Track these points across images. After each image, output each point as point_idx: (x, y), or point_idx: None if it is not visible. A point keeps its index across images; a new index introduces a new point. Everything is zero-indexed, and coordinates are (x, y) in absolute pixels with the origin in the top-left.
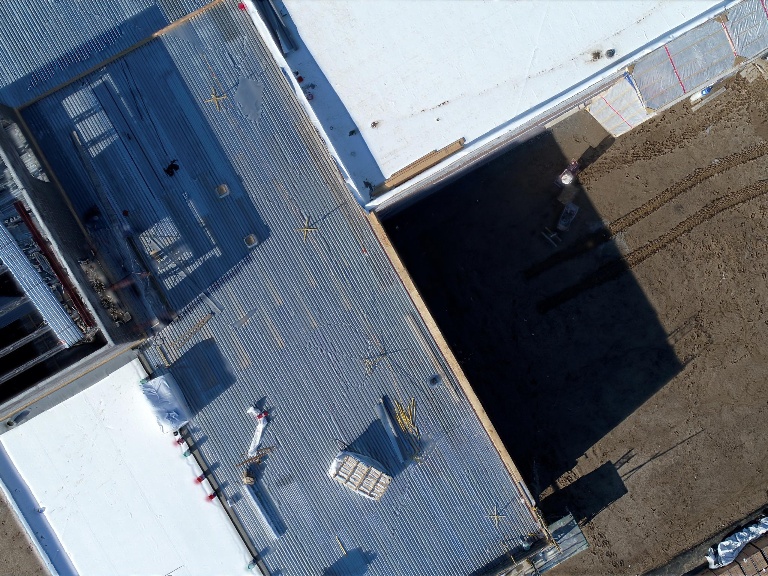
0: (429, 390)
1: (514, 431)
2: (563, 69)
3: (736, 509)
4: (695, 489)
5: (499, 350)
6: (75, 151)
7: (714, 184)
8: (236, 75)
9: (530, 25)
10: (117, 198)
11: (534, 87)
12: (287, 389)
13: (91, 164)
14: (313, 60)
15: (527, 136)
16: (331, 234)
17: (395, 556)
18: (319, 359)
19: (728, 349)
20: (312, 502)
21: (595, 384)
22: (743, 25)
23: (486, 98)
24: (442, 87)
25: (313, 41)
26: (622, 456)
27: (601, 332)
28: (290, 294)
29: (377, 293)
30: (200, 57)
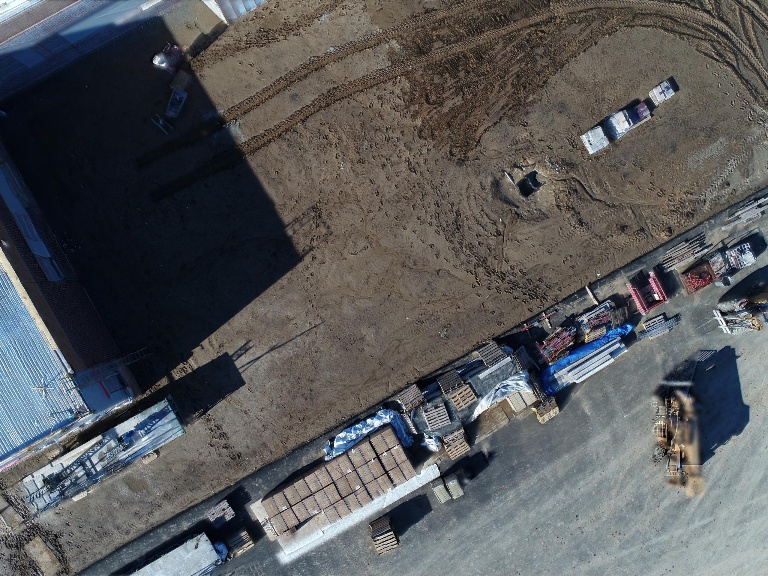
0: None
1: (127, 321)
2: None
3: (357, 402)
4: (315, 382)
5: (111, 238)
6: None
7: (330, 73)
8: None
9: None
10: None
11: None
12: None
13: None
14: None
15: (124, 18)
16: None
17: None
18: None
19: (348, 240)
20: None
21: (211, 274)
22: None
23: None
24: None
25: None
26: (239, 348)
27: (217, 222)
28: None
29: None
30: None
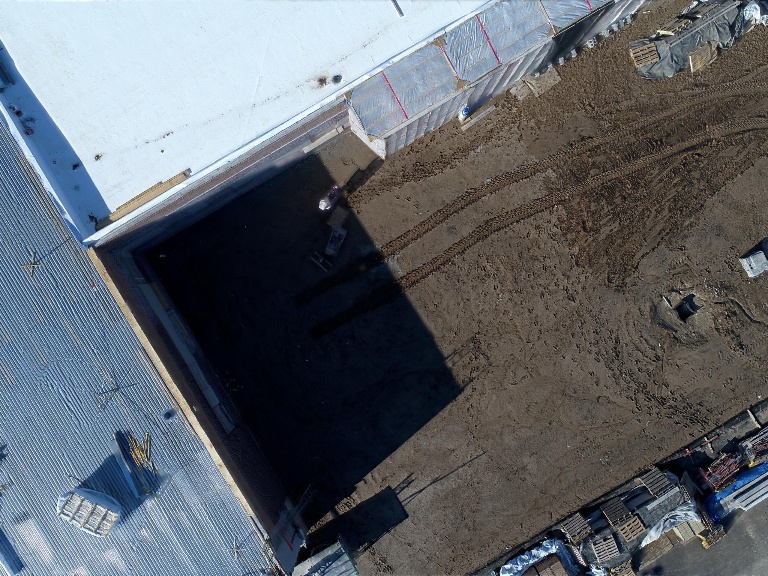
0: (163, 424)
1: (290, 458)
2: (289, 96)
3: (520, 532)
4: (477, 512)
5: (272, 377)
6: None
7: (487, 204)
8: None
9: (253, 53)
10: None
11: (260, 116)
12: (18, 426)
13: None
14: (32, 94)
15: (286, 161)
16: (58, 269)
17: None
18: (50, 396)
19: (507, 371)
20: (47, 539)
21: (372, 409)
22: (463, 48)
23: (211, 128)
24: (166, 118)
25: (31, 75)
26: (402, 481)
27: (377, 356)
28: (18, 331)
29: (107, 328)
30: None
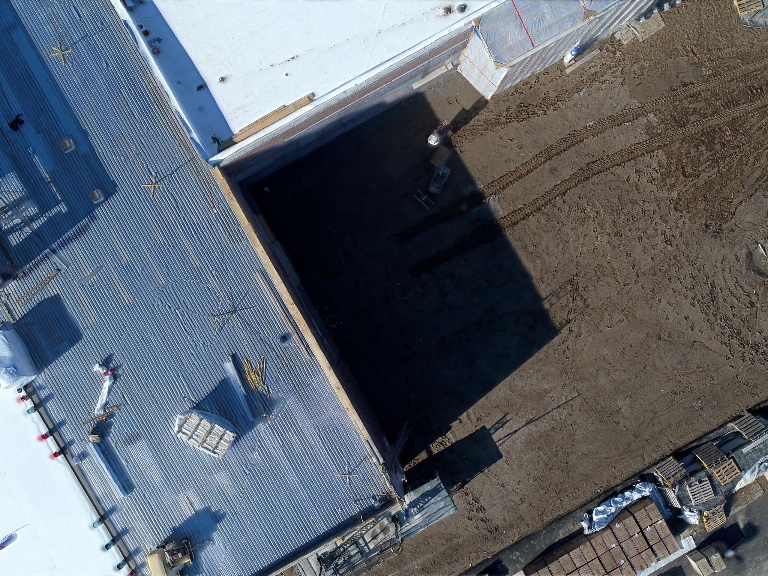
0: (279, 348)
1: (387, 395)
2: (414, 24)
3: (612, 475)
4: (571, 454)
5: (371, 314)
6: None
7: (589, 147)
8: (82, 29)
9: None
10: None
11: (384, 42)
12: (134, 346)
13: None
14: (159, 13)
15: (395, 96)
16: (179, 190)
17: (245, 515)
18: (167, 316)
19: (604, 313)
20: (160, 460)
21: (469, 348)
22: None
23: (336, 53)
24: (291, 41)
25: None
26: (497, 421)
27: (475, 296)
28: (137, 250)
29: (226, 250)
30: (45, 10)
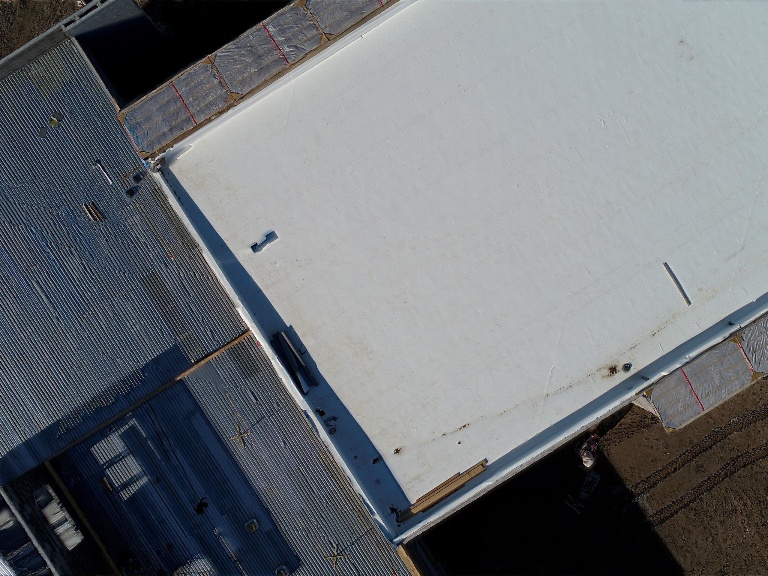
0: None
1: None
2: (581, 385)
3: None
4: None
5: None
6: (106, 496)
7: (734, 442)
8: (259, 411)
9: (546, 345)
10: (149, 538)
11: (553, 405)
12: None
13: (122, 508)
14: (334, 394)
15: None
16: (360, 560)
17: None
18: None
19: None
20: None
21: None
22: (759, 343)
23: (506, 419)
24: (462, 411)
25: (333, 375)
26: None
27: None
28: None
29: None
30: (223, 396)
